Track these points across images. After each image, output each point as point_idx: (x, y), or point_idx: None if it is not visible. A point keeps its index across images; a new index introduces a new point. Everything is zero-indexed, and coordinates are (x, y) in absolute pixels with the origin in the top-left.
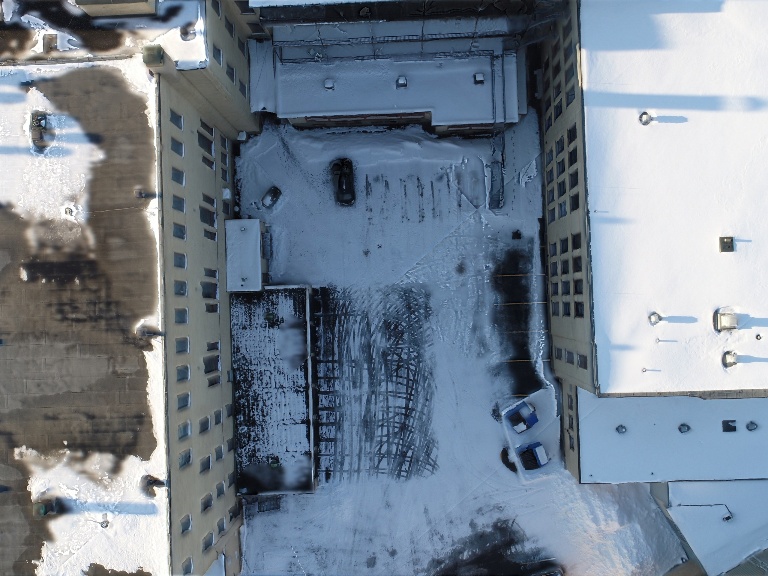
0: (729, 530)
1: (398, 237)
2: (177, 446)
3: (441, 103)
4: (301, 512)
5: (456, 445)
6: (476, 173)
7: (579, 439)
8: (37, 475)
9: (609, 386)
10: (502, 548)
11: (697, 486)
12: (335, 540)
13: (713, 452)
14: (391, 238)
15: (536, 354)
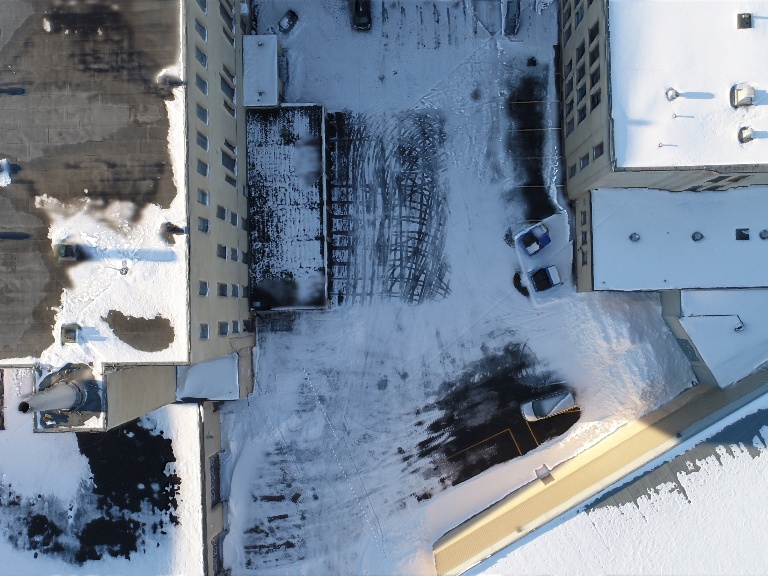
0: (741, 340)
1: (414, 63)
2: (196, 203)
3: None
4: (313, 334)
5: (469, 269)
6: None
7: (592, 246)
8: (58, 223)
9: (625, 160)
10: (513, 371)
11: (709, 296)
12: (347, 362)
13: (726, 260)
14: (407, 64)
15: (550, 180)
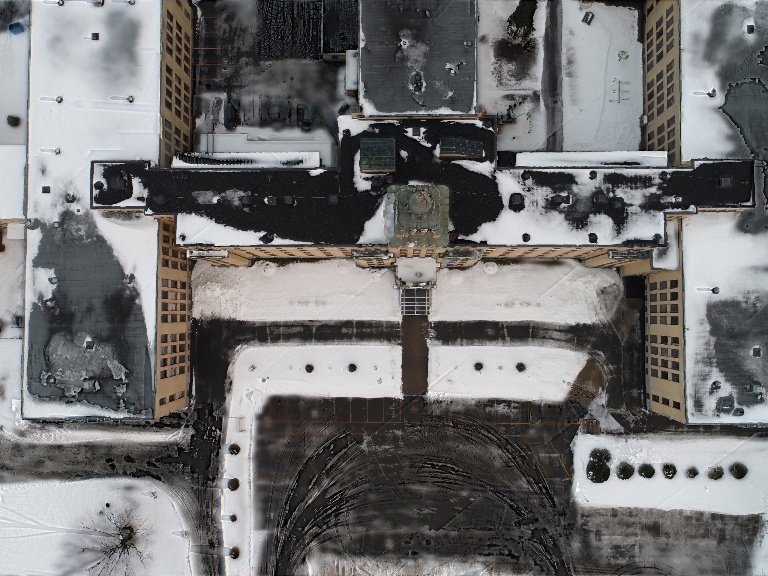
0: None
1: (275, 87)
2: None
3: (242, 146)
4: None
5: None
6: (229, 121)
7: None
8: None
9: None
10: None
11: None
12: None
13: None
14: (279, 86)
15: (202, 20)
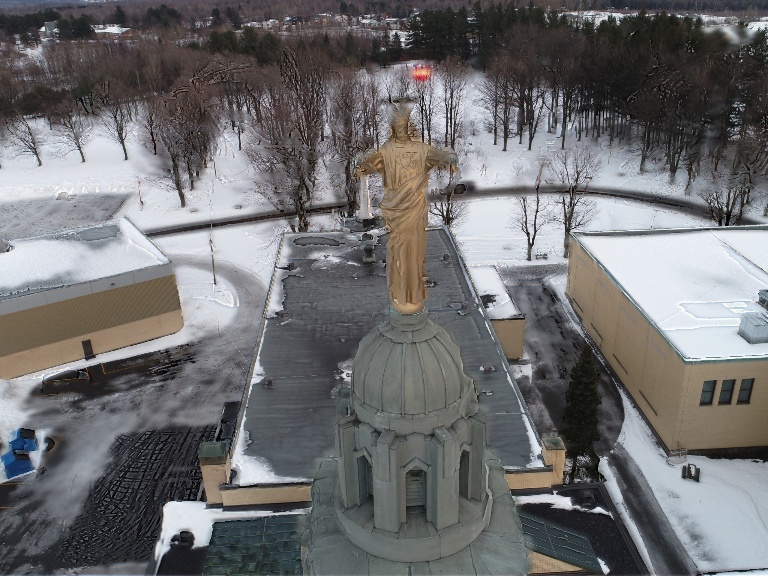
0: None
1: None
2: None
3: None
4: None
5: (92, 451)
6: None
7: None
8: (379, 268)
9: None
10: (86, 399)
11: None
12: (223, 397)
13: None
14: None
15: None
